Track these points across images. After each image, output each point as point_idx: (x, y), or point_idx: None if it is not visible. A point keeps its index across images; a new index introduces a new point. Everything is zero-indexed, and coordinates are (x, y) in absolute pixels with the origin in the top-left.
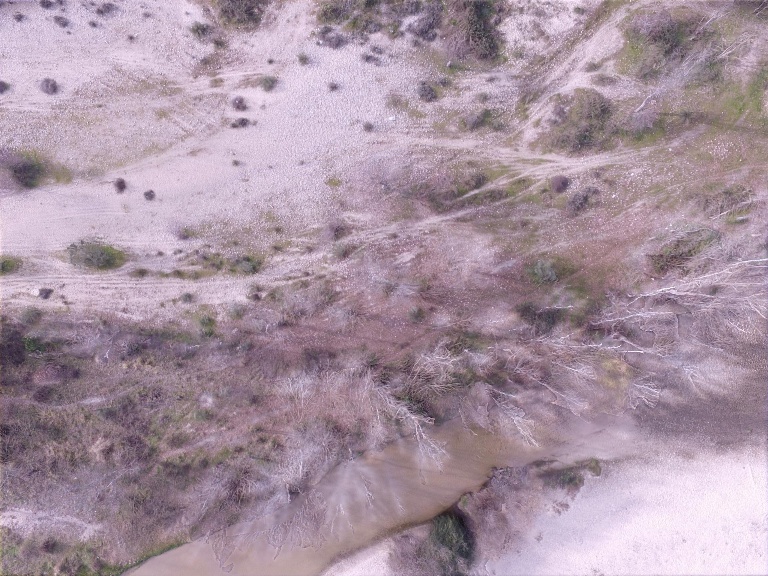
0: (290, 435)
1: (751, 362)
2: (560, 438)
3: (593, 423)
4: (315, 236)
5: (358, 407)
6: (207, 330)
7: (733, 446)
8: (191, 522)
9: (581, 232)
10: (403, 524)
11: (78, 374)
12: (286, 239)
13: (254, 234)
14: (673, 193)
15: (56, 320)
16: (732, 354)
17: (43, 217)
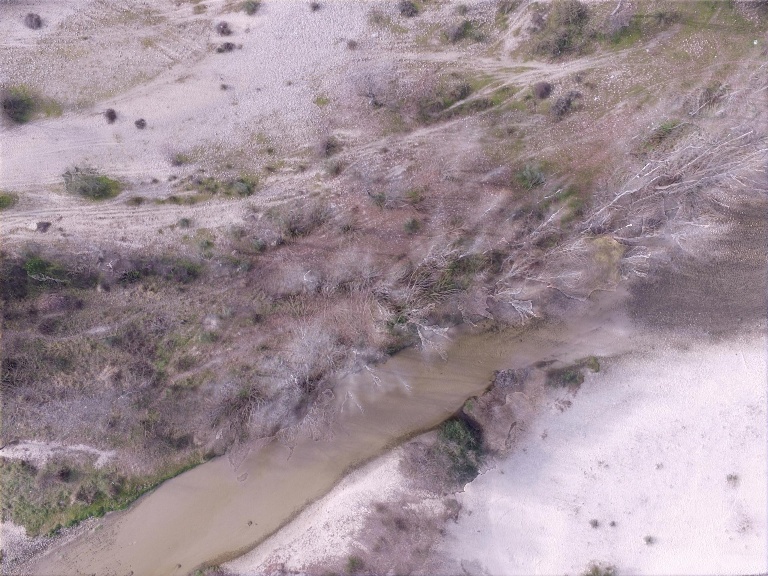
0: (295, 351)
1: (737, 253)
2: (558, 338)
3: (589, 322)
4: (307, 155)
5: (360, 320)
6: (206, 253)
7: (725, 334)
8: (203, 442)
9: (566, 136)
10: (411, 432)
11: (81, 305)
12: (278, 160)
13: (247, 156)
14: (653, 93)
15: (56, 253)
16: (719, 246)
17: (36, 152)
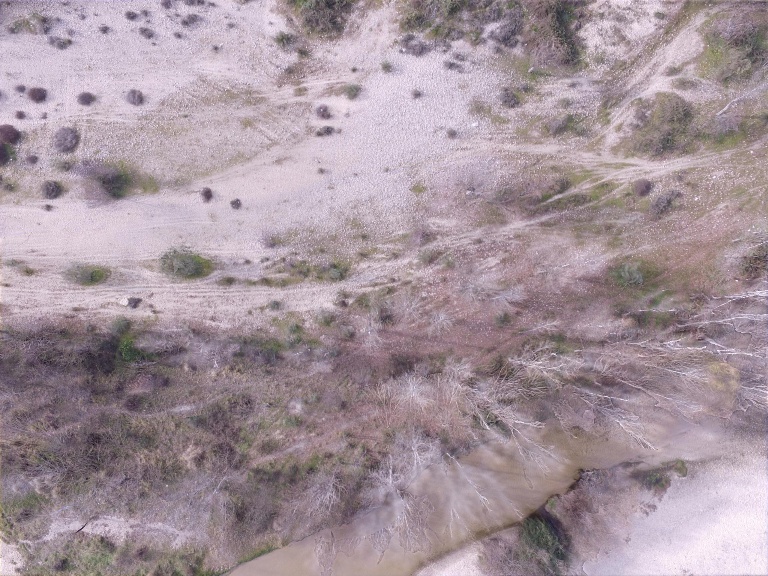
0: (379, 440)
1: None
2: None
3: (678, 424)
4: (400, 242)
5: (446, 411)
6: (295, 337)
7: None
8: (283, 528)
9: (664, 235)
10: (491, 527)
11: (168, 382)
12: (372, 246)
13: (340, 241)
14: (755, 195)
15: (145, 329)
16: None
17: (131, 227)
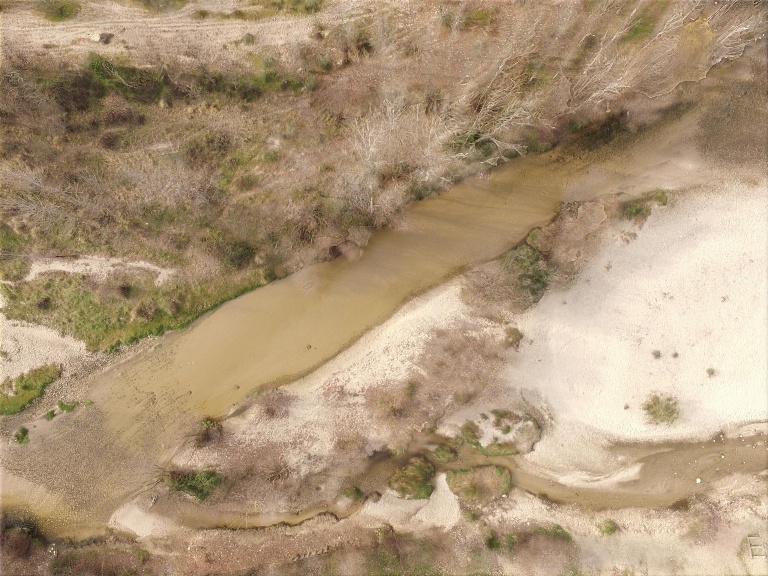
0: (359, 173)
1: None
2: (626, 171)
3: (658, 155)
4: None
5: (425, 144)
6: (271, 70)
7: None
8: (264, 261)
9: None
10: (473, 261)
11: (143, 120)
12: None
13: None
14: None
15: (118, 66)
16: None
17: None
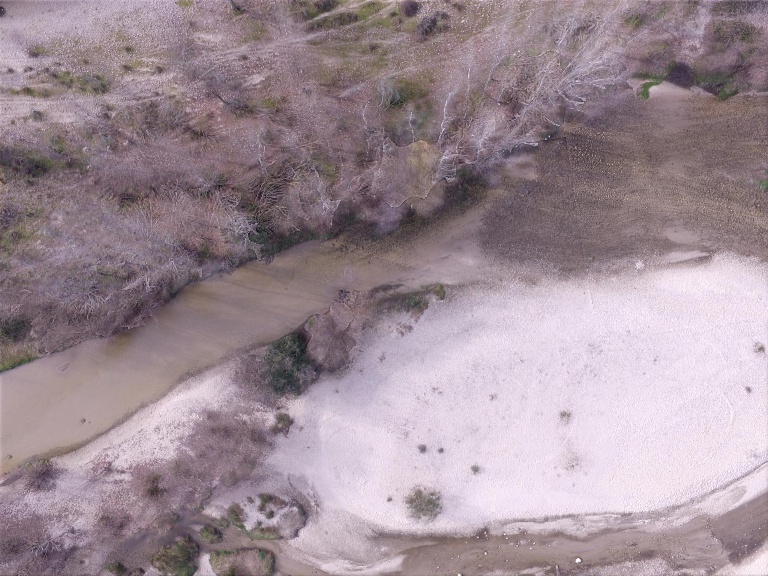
0: (138, 253)
1: (596, 191)
2: (407, 263)
3: (439, 249)
4: (165, 56)
5: (206, 227)
6: (57, 148)
7: (575, 272)
8: (40, 335)
9: (430, 57)
10: (251, 344)
11: None
12: (136, 59)
13: (104, 53)
14: (522, 19)
15: None
16: (577, 183)
17: None
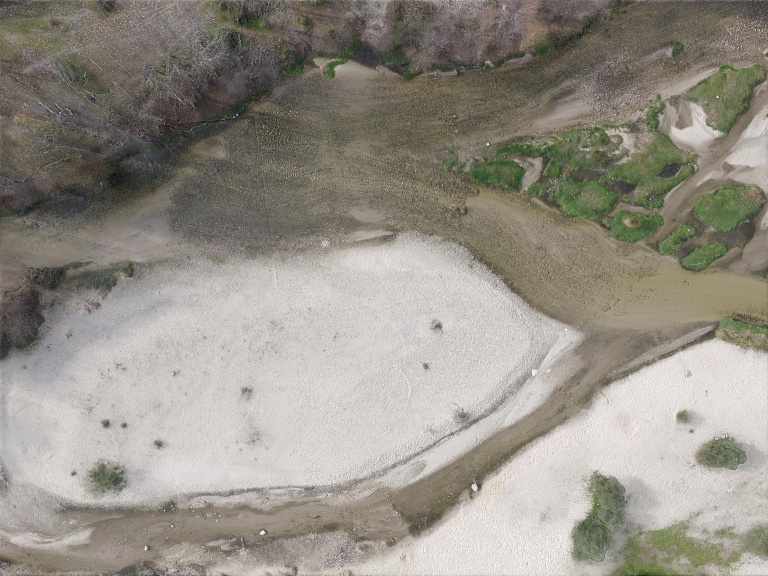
0: None
1: (283, 169)
2: (97, 241)
3: (129, 227)
4: None
5: None
6: None
7: (262, 250)
8: None
9: (112, 33)
10: None
11: None
12: None
13: None
14: None
15: None
16: (265, 161)
17: None
